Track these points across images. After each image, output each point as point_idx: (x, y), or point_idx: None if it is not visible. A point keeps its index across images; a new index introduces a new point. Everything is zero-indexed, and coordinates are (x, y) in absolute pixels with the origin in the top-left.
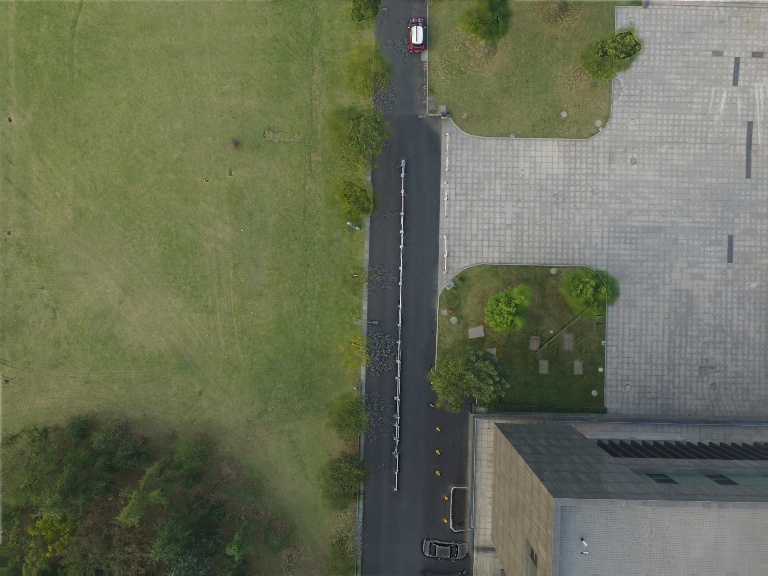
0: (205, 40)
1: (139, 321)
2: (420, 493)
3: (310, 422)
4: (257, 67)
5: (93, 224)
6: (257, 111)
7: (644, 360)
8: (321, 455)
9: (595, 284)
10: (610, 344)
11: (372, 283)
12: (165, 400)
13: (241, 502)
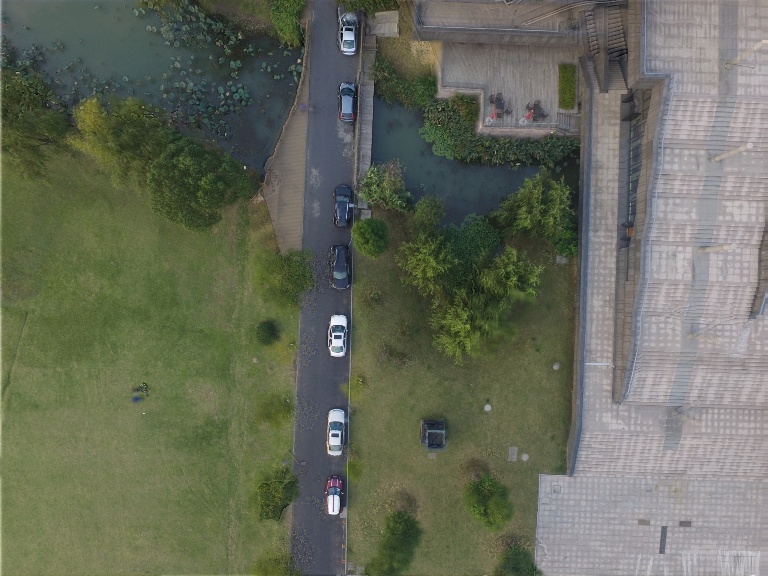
0: (118, 491)
1: None
2: None
3: None
4: (172, 520)
5: None
6: (171, 566)
7: None
8: None
9: None
10: None
11: None
12: None
13: None
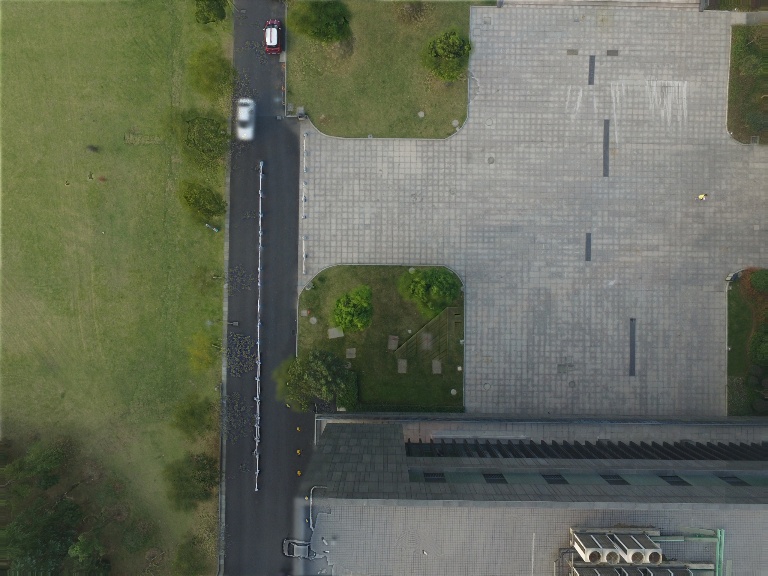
0: (65, 44)
1: (1, 324)
2: (282, 493)
3: (172, 423)
4: (117, 70)
5: None
6: (117, 114)
7: (503, 359)
8: (183, 456)
9: (425, 284)
10: (469, 343)
11: (232, 284)
12: (28, 403)
13: (101, 503)
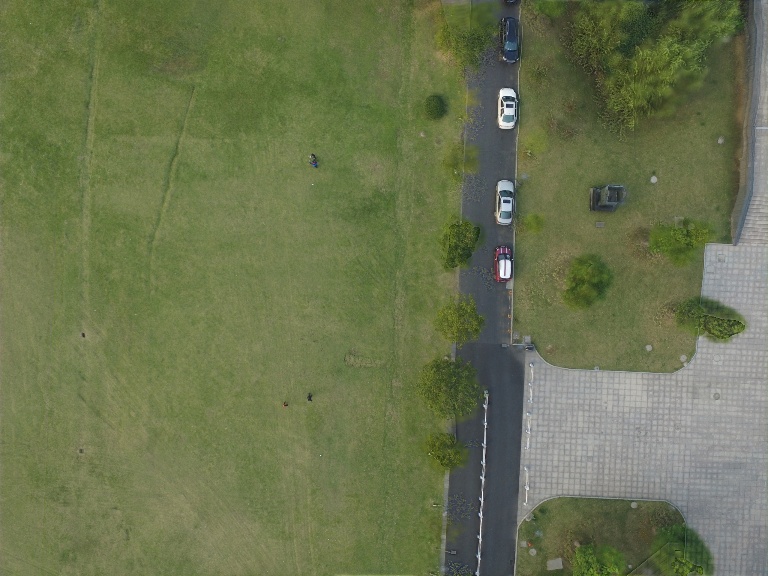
0: (286, 261)
1: (214, 546)
2: None
3: None
4: (339, 290)
5: (168, 445)
6: (338, 335)
7: None
8: None
9: (692, 566)
10: None
11: (451, 513)
12: None
13: None
